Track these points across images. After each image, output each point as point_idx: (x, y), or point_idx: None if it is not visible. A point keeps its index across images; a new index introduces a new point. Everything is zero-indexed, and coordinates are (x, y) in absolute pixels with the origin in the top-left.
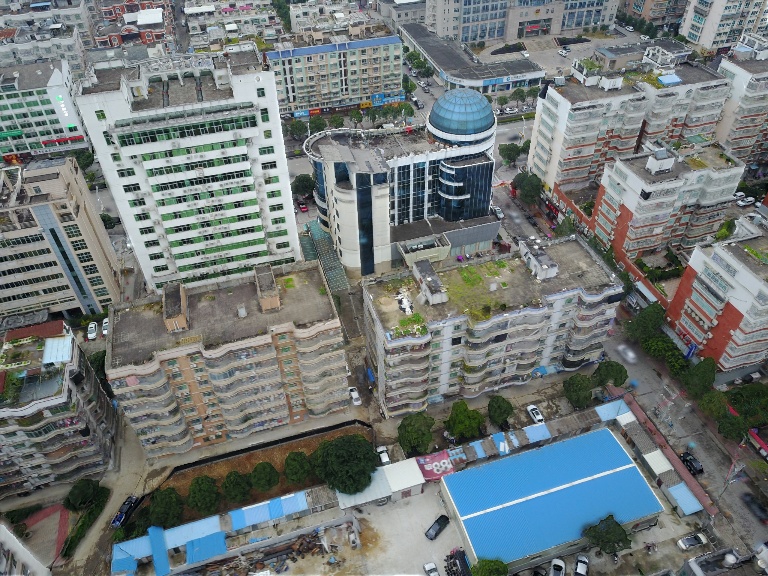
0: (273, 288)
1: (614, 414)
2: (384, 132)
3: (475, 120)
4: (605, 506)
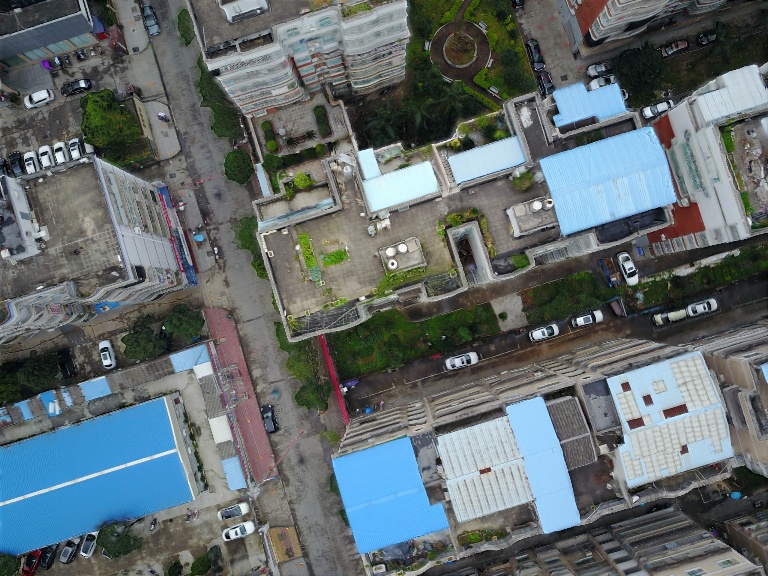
0: None
1: (192, 363)
2: None
3: None
4: (133, 496)
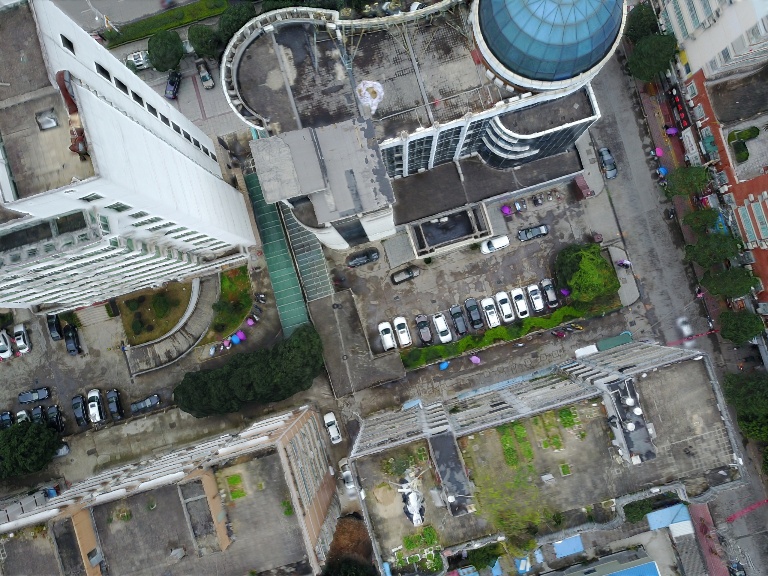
0: (213, 532)
1: (668, 521)
2: (383, 22)
3: (579, 57)
4: None
